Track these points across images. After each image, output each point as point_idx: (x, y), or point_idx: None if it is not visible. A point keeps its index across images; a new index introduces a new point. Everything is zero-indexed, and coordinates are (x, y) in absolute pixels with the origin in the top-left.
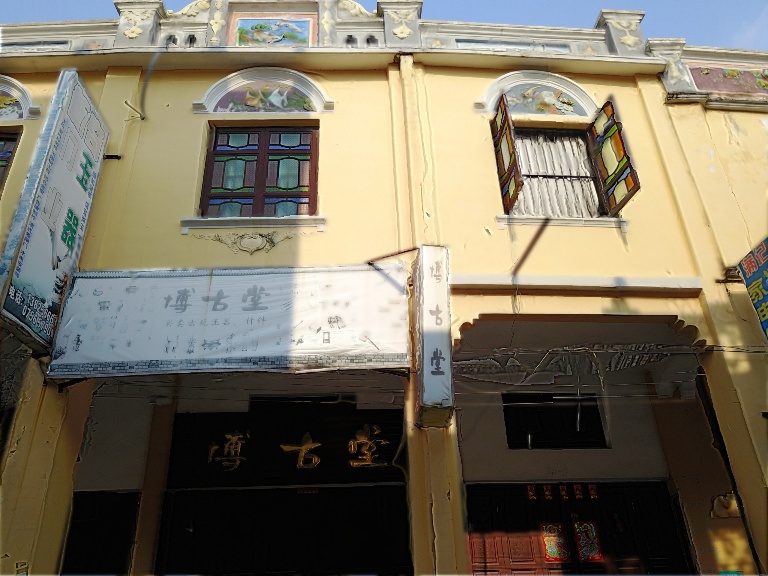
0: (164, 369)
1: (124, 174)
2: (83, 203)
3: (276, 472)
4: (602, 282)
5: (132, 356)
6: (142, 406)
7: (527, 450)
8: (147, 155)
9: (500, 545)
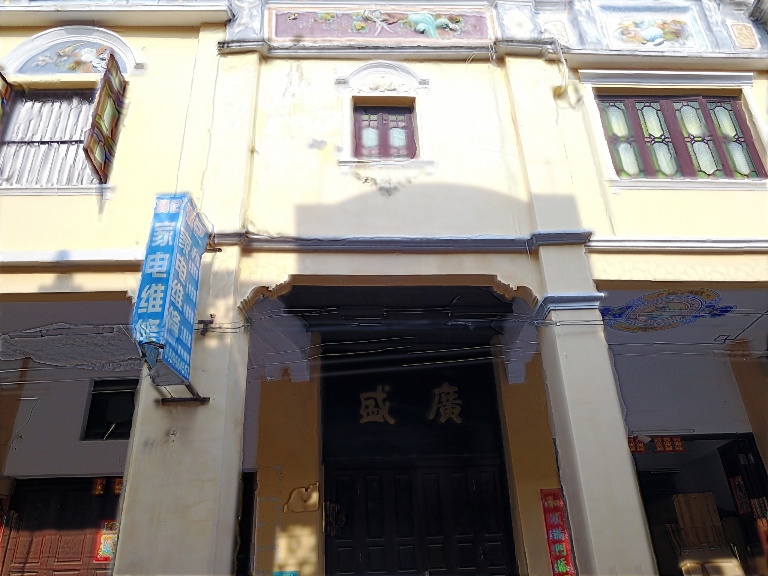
0: None
1: None
2: None
3: None
4: (42, 256)
5: None
6: None
7: (99, 441)
8: None
9: (48, 544)
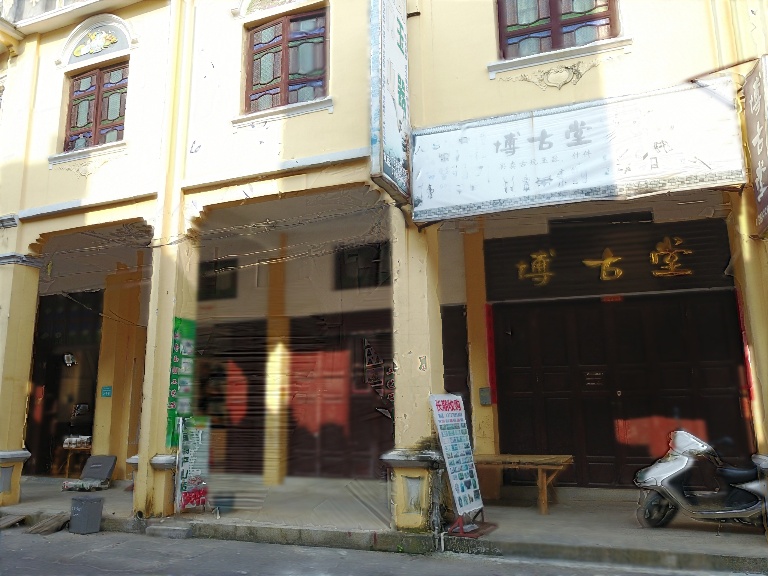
0: (507, 207)
1: (426, 29)
2: (404, 66)
3: (581, 284)
4: None
5: (477, 198)
6: (453, 235)
7: None
8: (443, 5)
9: None
